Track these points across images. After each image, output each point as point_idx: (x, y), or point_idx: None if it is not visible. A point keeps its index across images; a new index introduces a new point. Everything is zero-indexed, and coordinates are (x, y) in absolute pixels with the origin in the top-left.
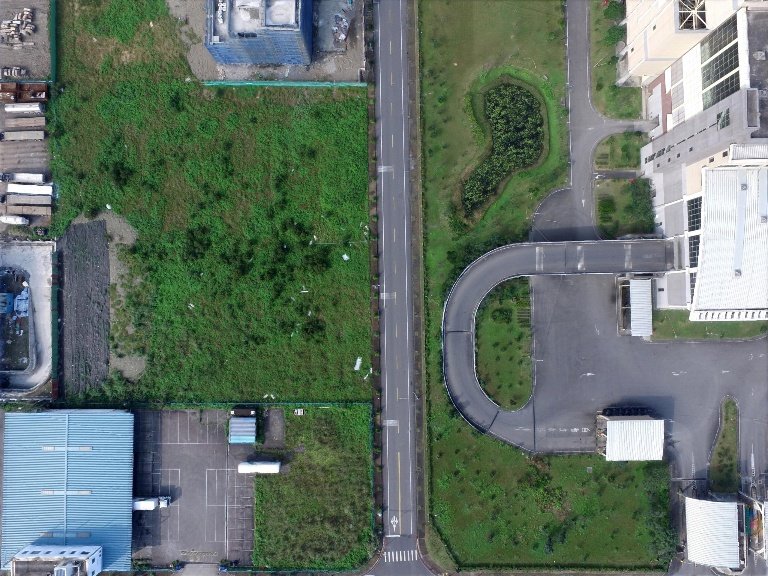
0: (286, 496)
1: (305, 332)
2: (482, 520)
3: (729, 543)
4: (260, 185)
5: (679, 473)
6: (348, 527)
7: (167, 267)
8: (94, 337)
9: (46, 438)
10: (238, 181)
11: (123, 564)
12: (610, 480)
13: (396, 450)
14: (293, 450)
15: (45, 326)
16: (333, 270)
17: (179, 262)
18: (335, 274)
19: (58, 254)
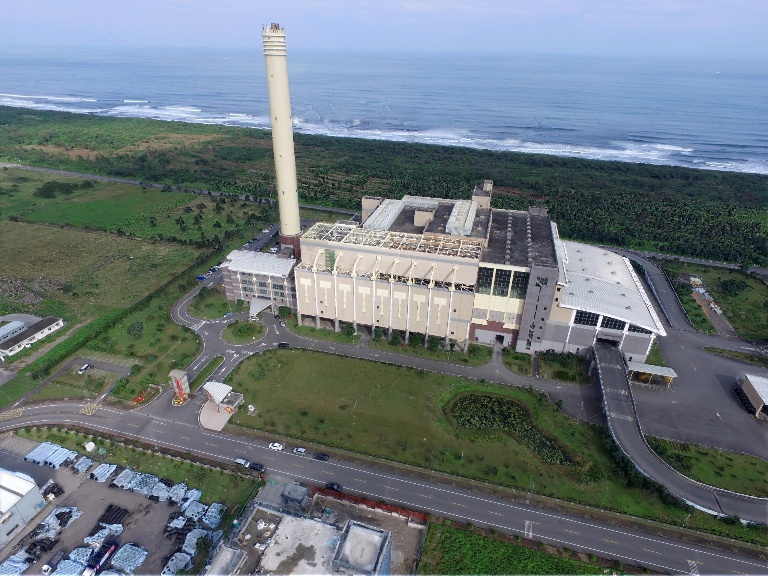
0: None
1: None
2: None
3: None
4: None
5: None
6: None
7: None
8: None
9: None
10: None
11: None
12: None
13: None
14: None
15: None
16: None
17: None
18: None
19: None
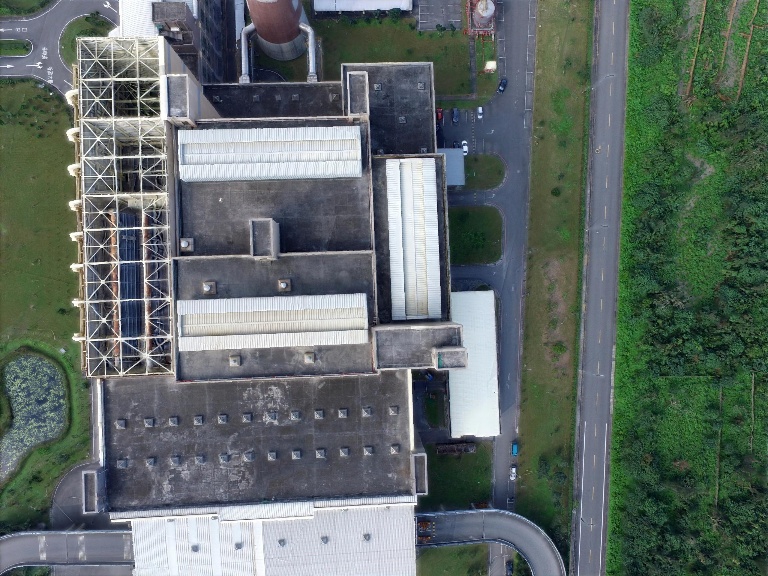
0: None
1: None
2: None
3: None
4: None
5: None
6: None
7: None
8: None
9: None
10: None
11: None
12: None
13: None
14: None
15: None
16: None
17: None
18: None
19: None
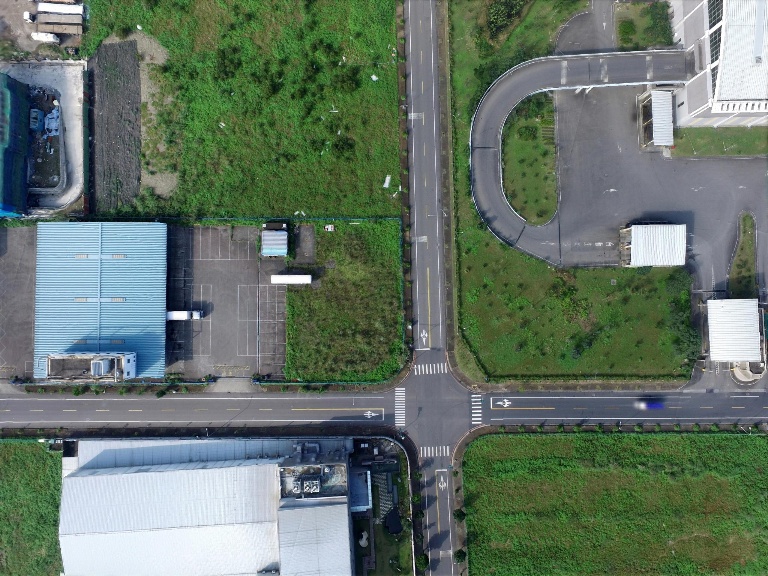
0: (317, 311)
1: (335, 148)
2: (510, 332)
3: (751, 338)
4: (290, 7)
5: (700, 285)
6: (379, 338)
7: (198, 86)
8: (125, 154)
9: (79, 246)
10: (268, 3)
11: (157, 371)
12: (634, 290)
13: (425, 265)
14: (324, 266)
15: (76, 146)
16: (362, 90)
17: (210, 81)
18: (364, 94)
19: (89, 73)
